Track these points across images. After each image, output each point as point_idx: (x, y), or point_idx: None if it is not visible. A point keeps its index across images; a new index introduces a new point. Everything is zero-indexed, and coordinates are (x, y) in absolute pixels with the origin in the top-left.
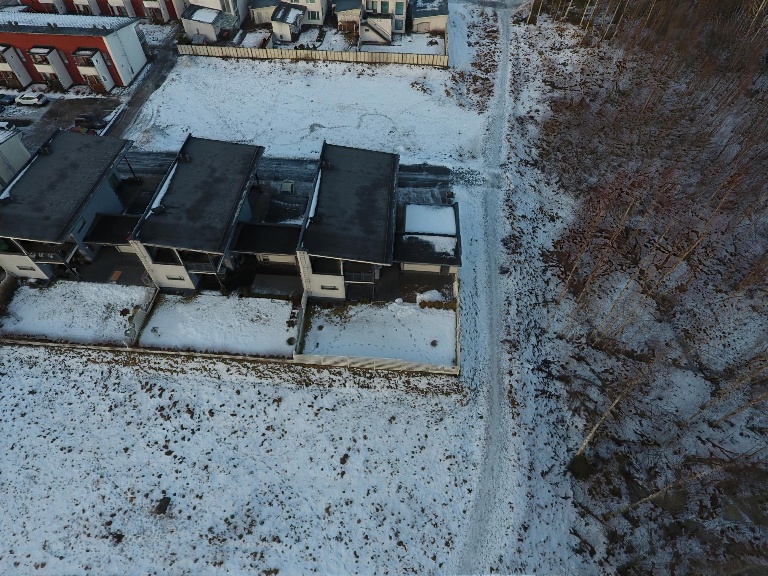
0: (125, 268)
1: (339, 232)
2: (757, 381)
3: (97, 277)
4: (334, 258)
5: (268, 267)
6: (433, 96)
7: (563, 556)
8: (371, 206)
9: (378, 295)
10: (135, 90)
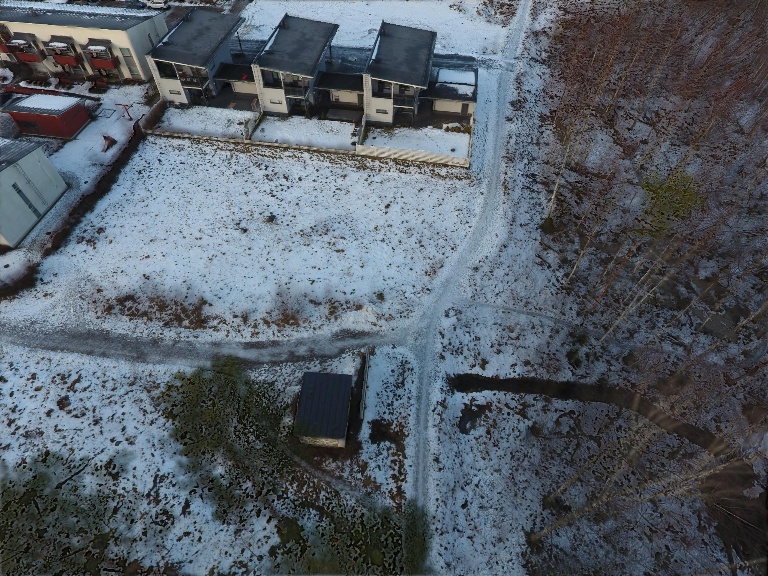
0: (238, 102)
1: (392, 68)
2: (688, 194)
3: (220, 105)
4: (388, 81)
5: (338, 105)
6: (467, 14)
7: (529, 265)
8: (415, 57)
9: (415, 122)
10: (234, 2)
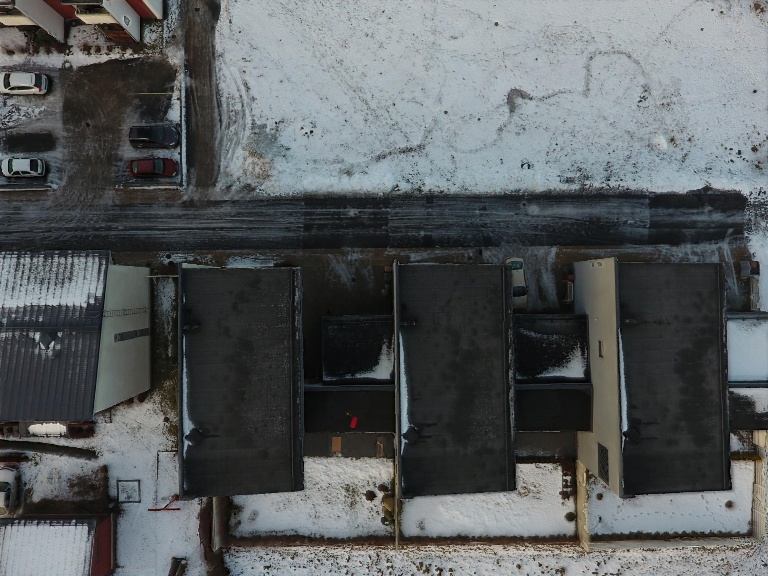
0: None
1: (664, 450)
2: None
3: (315, 449)
4: None
5: None
6: None
7: None
8: (698, 390)
9: None
10: (181, 27)
